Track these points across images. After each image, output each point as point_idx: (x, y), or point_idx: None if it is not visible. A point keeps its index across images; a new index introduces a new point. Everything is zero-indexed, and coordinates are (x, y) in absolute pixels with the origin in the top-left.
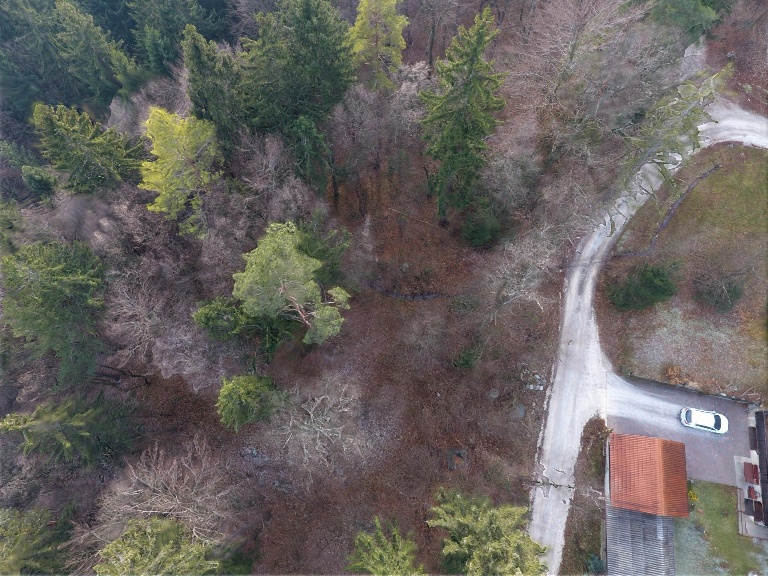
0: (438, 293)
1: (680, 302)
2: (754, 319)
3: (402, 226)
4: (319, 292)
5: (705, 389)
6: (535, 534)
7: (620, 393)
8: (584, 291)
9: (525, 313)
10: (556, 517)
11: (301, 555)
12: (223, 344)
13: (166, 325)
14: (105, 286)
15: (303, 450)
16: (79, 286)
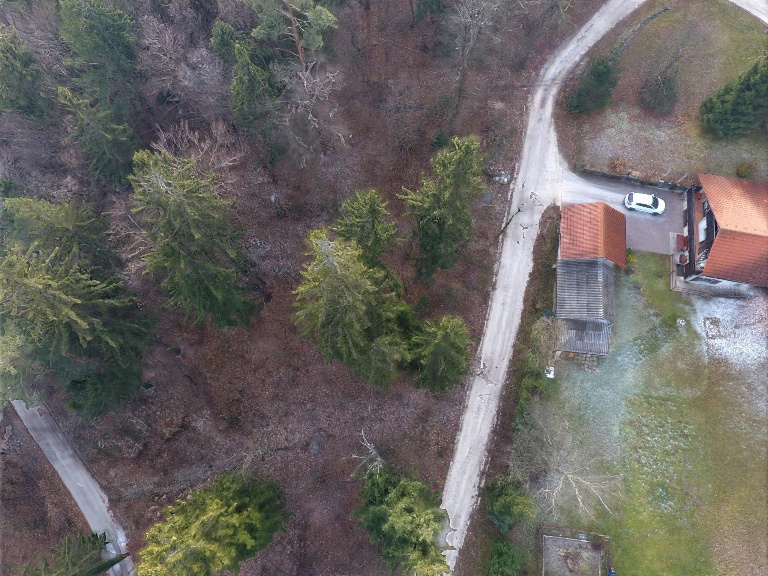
0: (419, 107)
1: (627, 107)
2: (690, 122)
3: (388, 52)
4: (312, 2)
5: (646, 178)
6: (498, 301)
7: (574, 186)
8: (545, 105)
9: (493, 118)
10: (517, 287)
11: (297, 325)
12: (235, 64)
13: (188, 54)
14: (139, 28)
15: (300, 239)
16: (117, 27)
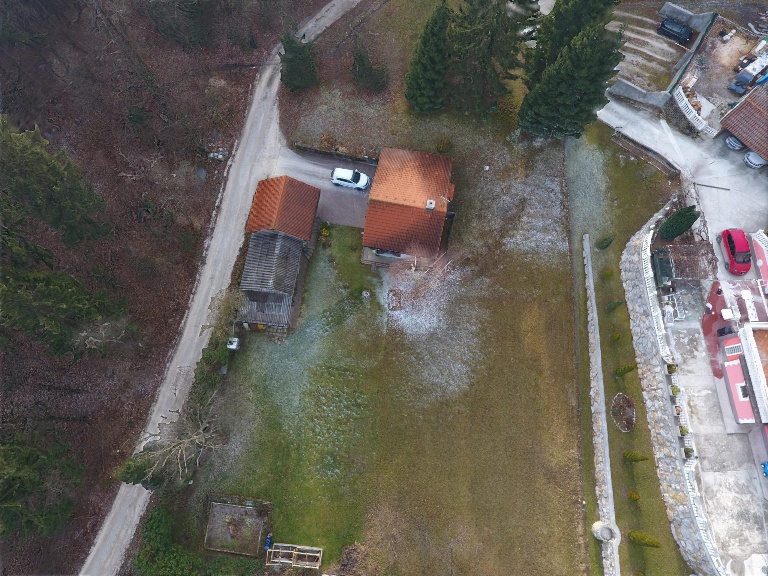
0: (149, 86)
1: (340, 85)
2: (401, 98)
3: None
4: None
5: (354, 154)
6: (207, 275)
7: (288, 162)
8: (272, 84)
9: (212, 96)
10: (226, 262)
11: None
12: None
13: None
14: None
15: None
16: None
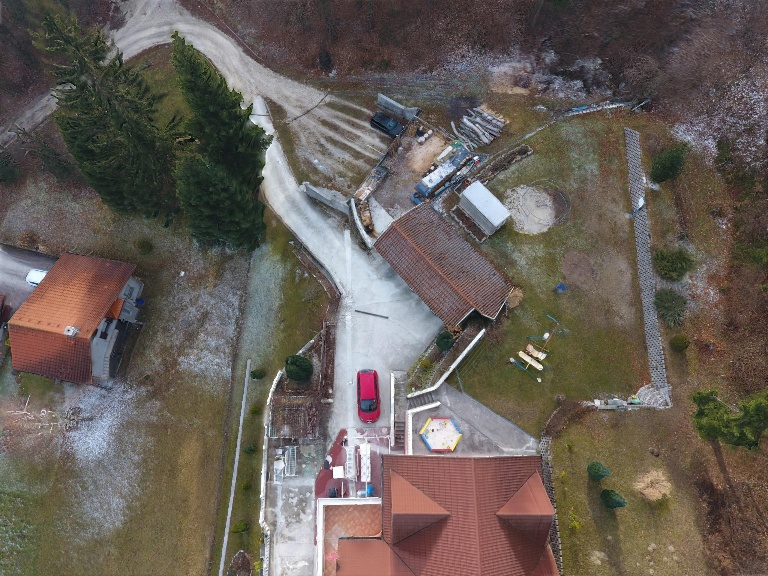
0: None
1: (47, 177)
2: None
3: None
4: None
5: (55, 253)
6: None
7: None
8: None
9: None
10: None
11: None
12: None
13: None
14: None
15: None
16: None
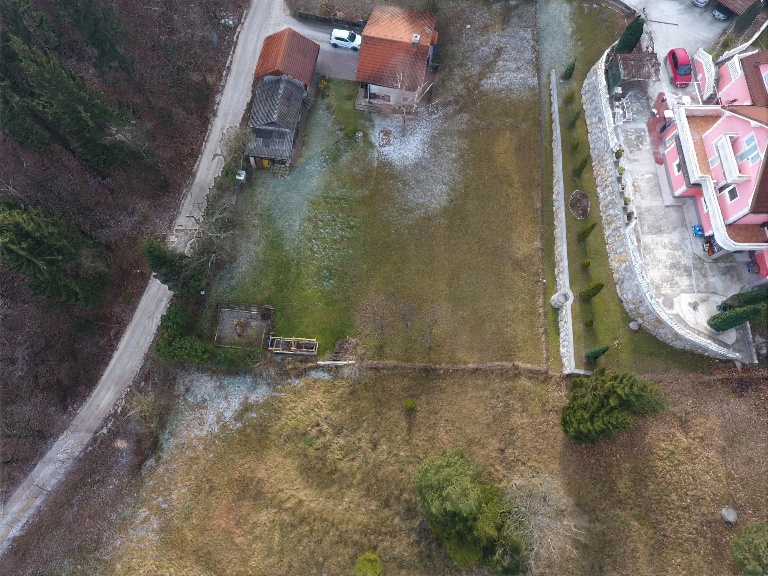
0: None
1: None
2: None
3: None
4: None
5: (350, 19)
6: (218, 126)
7: (292, 28)
8: None
9: None
10: (235, 114)
11: None
12: None
13: None
14: None
15: None
16: None
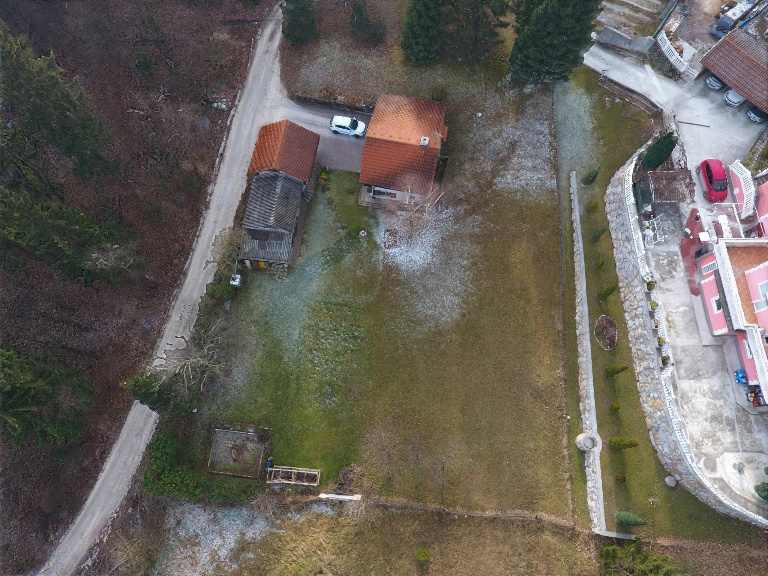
0: (155, 41)
1: (339, 37)
2: (398, 50)
3: None
4: None
5: (352, 103)
6: (210, 219)
7: (289, 112)
8: (274, 38)
9: (216, 48)
10: (229, 206)
11: None
12: None
13: None
14: None
15: None
16: None
